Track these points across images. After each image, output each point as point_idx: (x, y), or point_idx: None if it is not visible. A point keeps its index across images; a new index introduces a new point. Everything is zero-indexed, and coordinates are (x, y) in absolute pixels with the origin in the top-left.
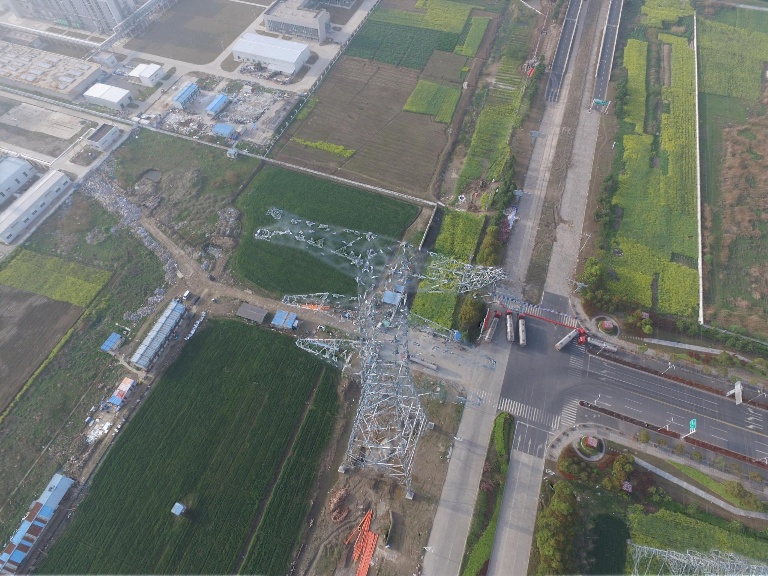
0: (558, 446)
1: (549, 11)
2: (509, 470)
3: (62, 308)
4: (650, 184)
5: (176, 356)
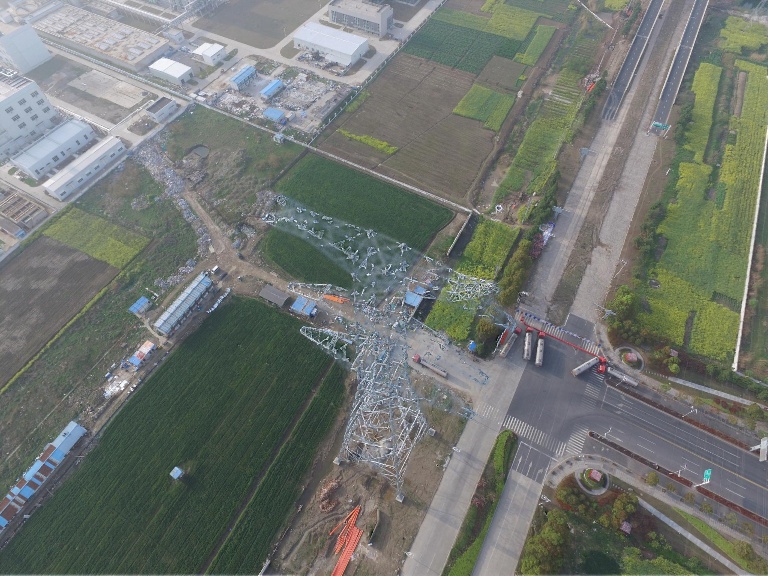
0: (559, 474)
1: (620, 26)
2: (504, 490)
3: (100, 267)
4: (701, 217)
5: (197, 327)
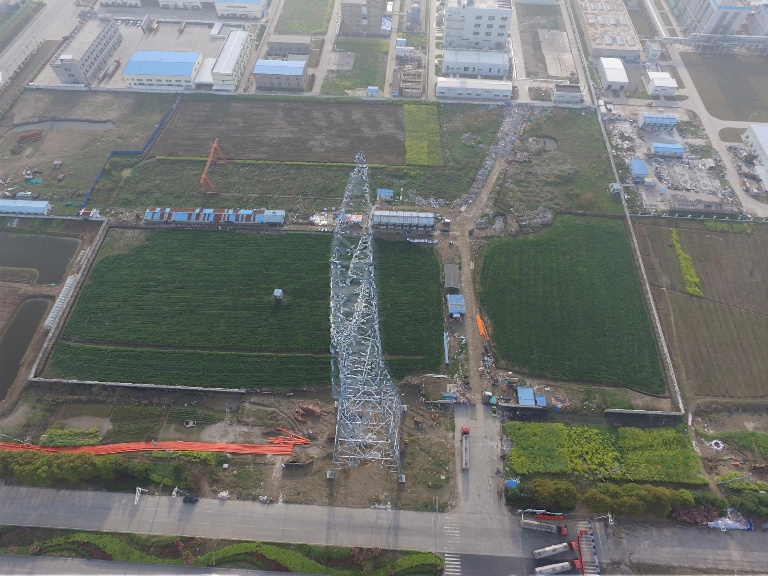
0: None
1: None
2: None
3: (401, 152)
4: None
5: (391, 239)
